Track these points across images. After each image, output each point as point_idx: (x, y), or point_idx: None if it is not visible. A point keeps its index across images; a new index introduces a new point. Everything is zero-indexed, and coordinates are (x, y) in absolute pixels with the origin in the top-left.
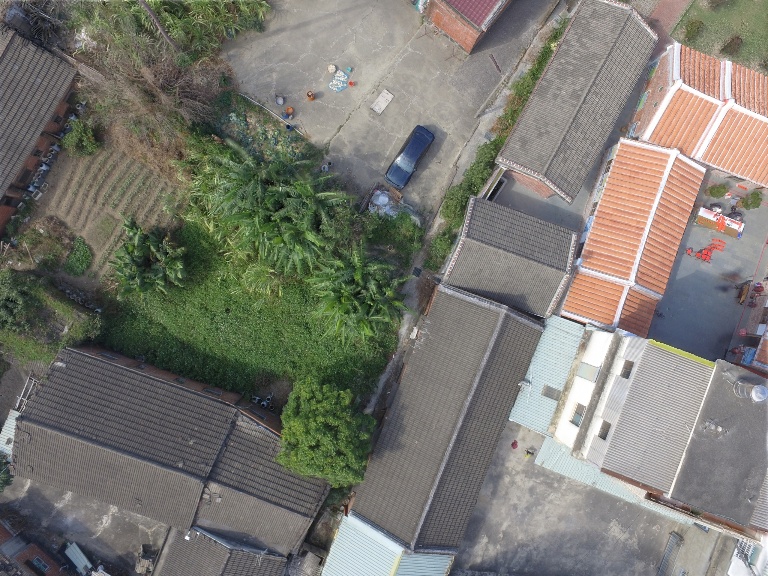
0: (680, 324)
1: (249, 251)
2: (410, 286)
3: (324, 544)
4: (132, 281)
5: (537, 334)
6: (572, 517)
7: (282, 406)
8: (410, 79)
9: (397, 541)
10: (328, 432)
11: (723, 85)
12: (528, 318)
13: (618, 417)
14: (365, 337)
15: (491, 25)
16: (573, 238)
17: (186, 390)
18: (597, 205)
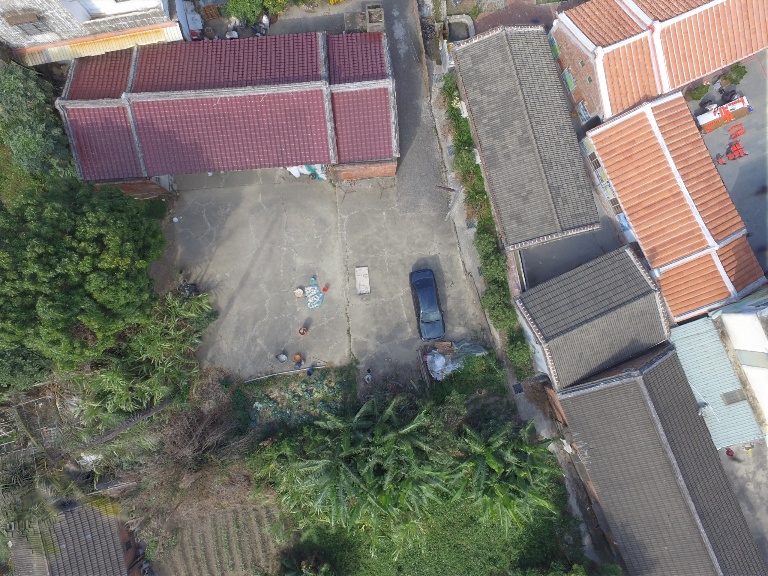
0: None
1: None
2: (523, 405)
3: None
4: None
5: (674, 358)
6: None
7: None
8: (367, 240)
9: None
10: None
11: (632, 14)
12: (657, 356)
13: None
14: None
15: None
16: (629, 254)
17: None
18: (620, 205)
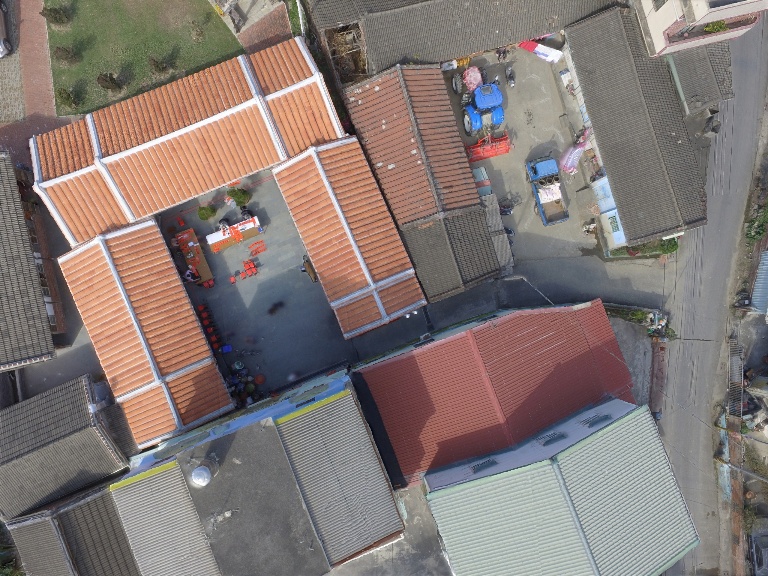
0: (285, 341)
1: None
2: None
3: None
4: None
5: None
6: None
7: None
8: None
9: None
10: None
11: None
12: (99, 488)
13: (143, 575)
14: None
15: None
16: (83, 384)
17: None
18: (88, 332)
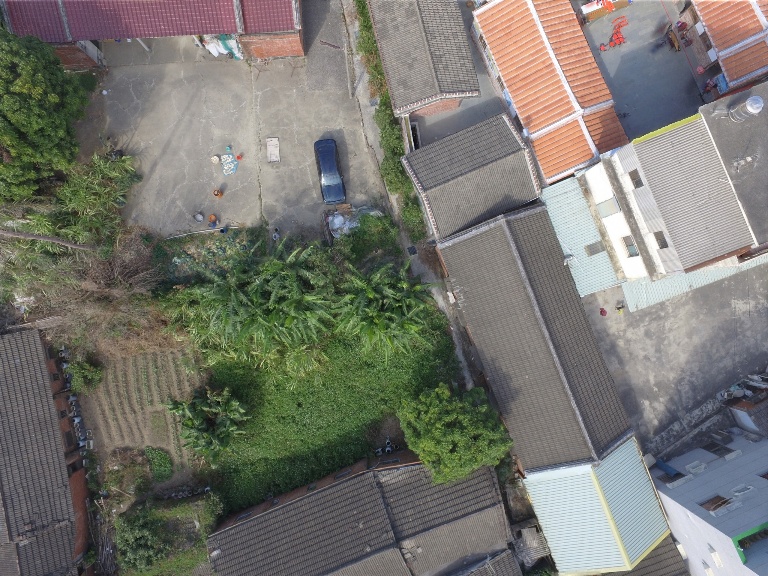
0: (646, 108)
1: (276, 347)
2: (416, 265)
3: (527, 514)
4: (212, 446)
5: (544, 215)
6: (697, 327)
7: (403, 439)
8: (278, 114)
9: (580, 463)
10: (454, 428)
11: None
12: (526, 209)
13: (662, 221)
14: (418, 333)
15: (301, 20)
16: (505, 119)
17: (322, 490)
18: (501, 78)
